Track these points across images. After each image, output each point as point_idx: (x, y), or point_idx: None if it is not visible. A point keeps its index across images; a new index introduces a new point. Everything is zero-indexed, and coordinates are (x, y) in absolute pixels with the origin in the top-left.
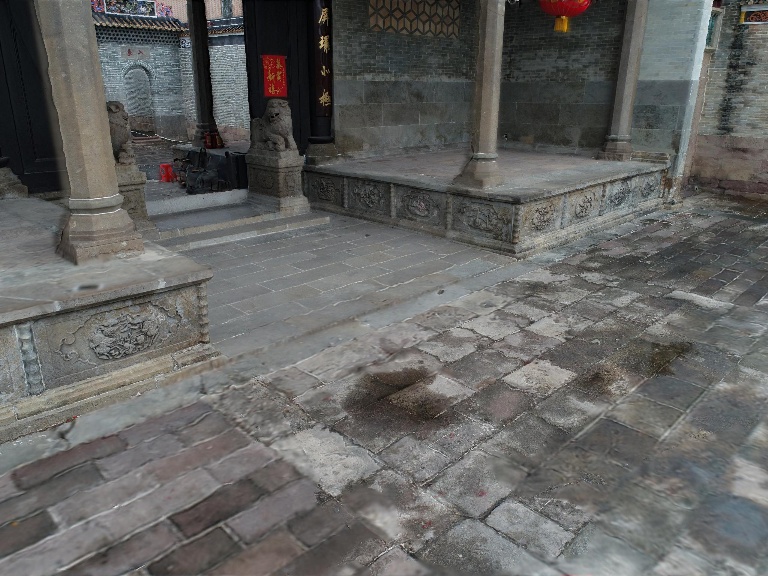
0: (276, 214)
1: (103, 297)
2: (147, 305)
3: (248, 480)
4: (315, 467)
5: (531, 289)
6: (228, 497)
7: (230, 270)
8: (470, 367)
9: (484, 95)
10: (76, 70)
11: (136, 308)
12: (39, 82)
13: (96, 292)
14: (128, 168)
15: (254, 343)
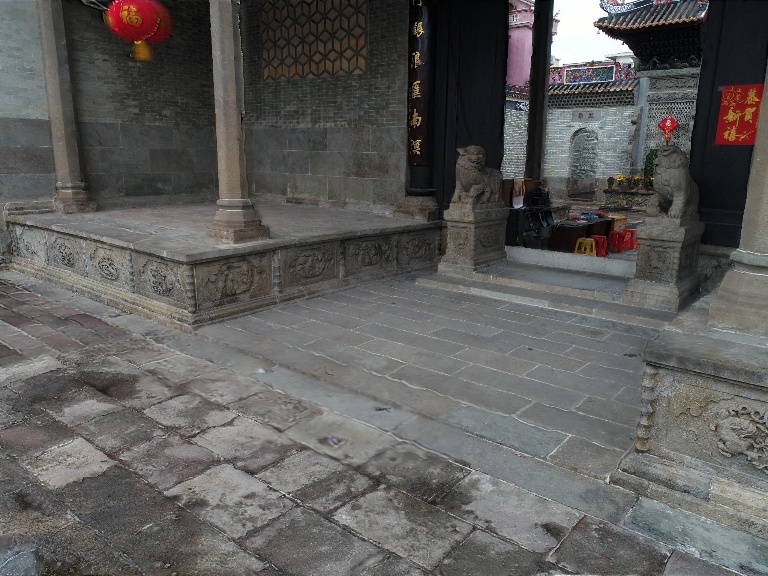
0: (616, 296)
1: (145, 249)
2: (168, 267)
3: (15, 354)
4: (7, 368)
5: (416, 484)
6: (1, 351)
7: (412, 311)
8: (121, 420)
9: (762, 120)
10: (218, 114)
11: (164, 266)
12: (465, 132)
13: (145, 245)
14: (464, 207)
15: (218, 334)
